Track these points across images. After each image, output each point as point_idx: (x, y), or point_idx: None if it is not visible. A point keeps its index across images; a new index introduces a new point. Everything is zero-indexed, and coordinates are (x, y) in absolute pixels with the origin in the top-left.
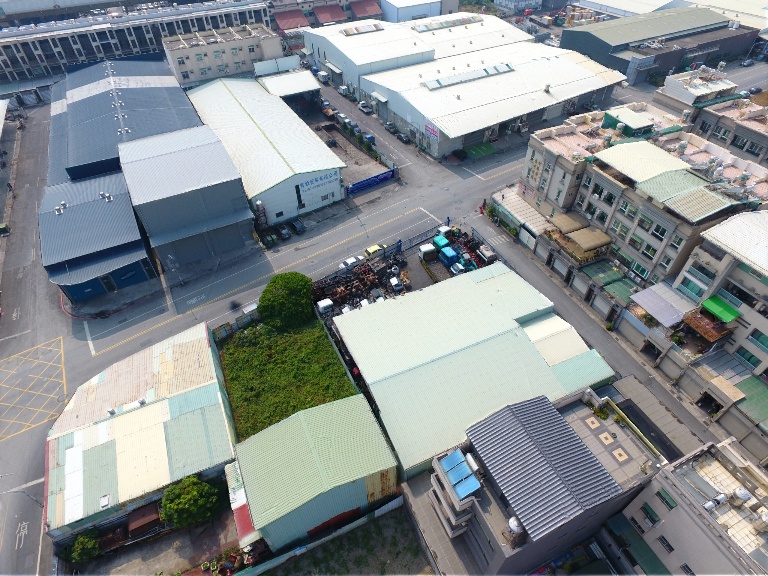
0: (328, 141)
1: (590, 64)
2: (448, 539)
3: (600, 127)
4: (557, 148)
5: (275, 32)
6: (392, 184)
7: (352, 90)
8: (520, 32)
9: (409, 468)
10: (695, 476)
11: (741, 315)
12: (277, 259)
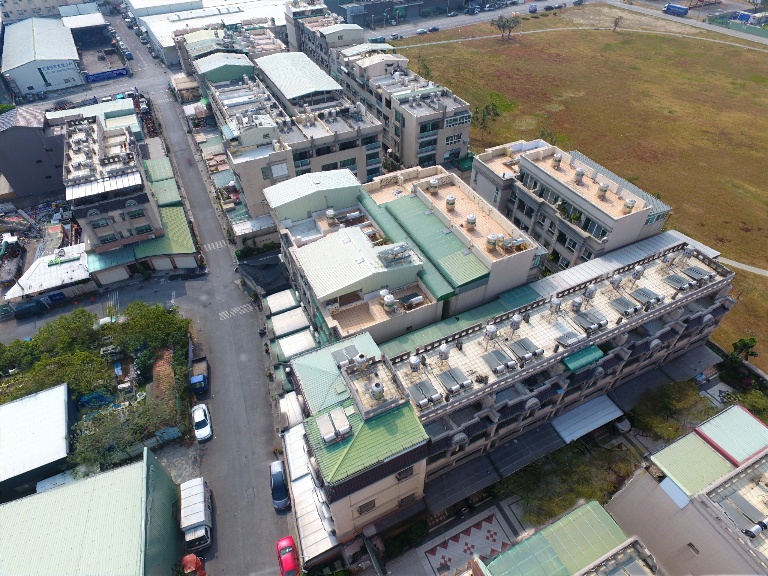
0: (98, 56)
1: None
2: None
3: None
4: None
5: None
6: (124, 77)
7: (140, 29)
8: None
9: None
10: None
11: (210, 102)
12: None
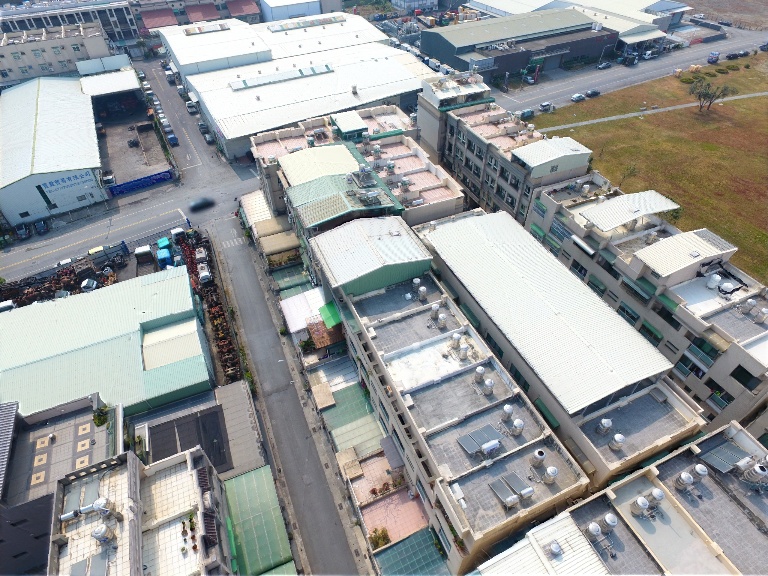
0: (129, 141)
1: (416, 66)
2: None
3: None
4: (272, 151)
5: None
6: (167, 185)
7: (186, 90)
8: (377, 33)
9: None
10: (94, 485)
11: (342, 322)
12: (1, 259)
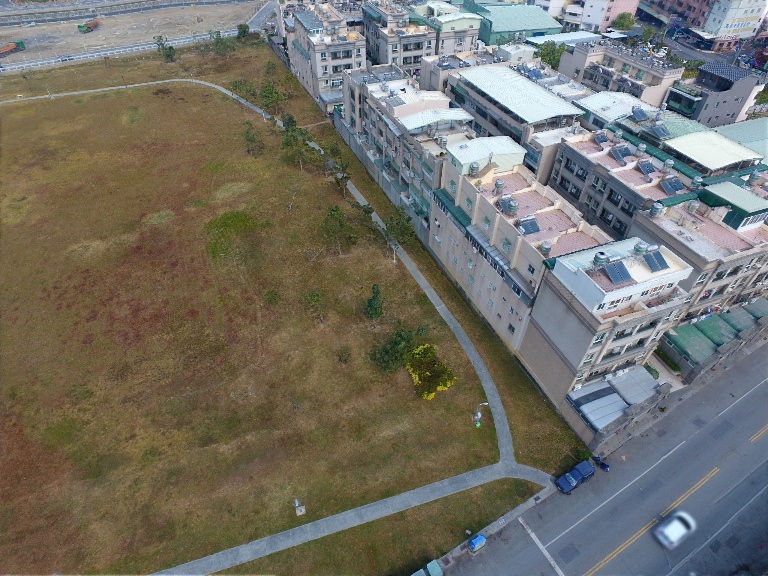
0: None
1: None
2: None
3: (763, 222)
4: None
5: None
6: None
7: None
8: None
9: (762, 117)
10: None
11: None
12: None
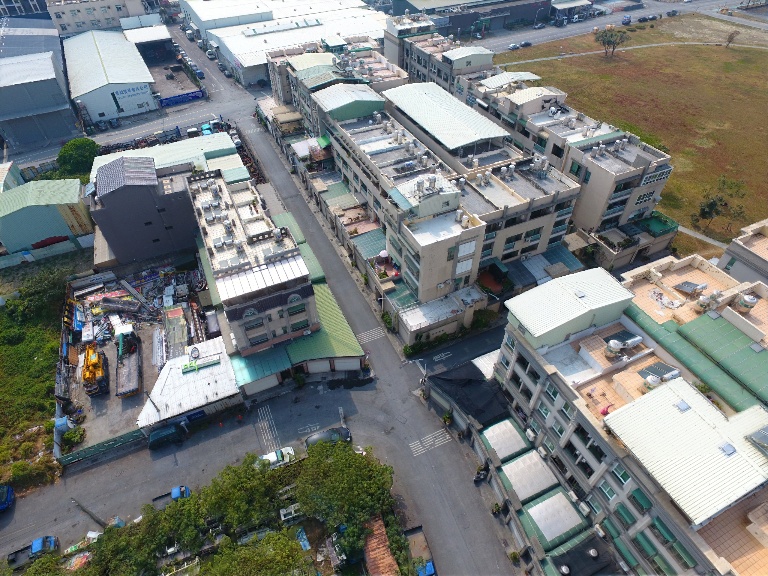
0: (167, 75)
1: None
2: (107, 243)
3: None
4: None
5: (161, 1)
6: (201, 101)
7: (205, 43)
8: (357, 1)
9: None
10: (204, 182)
11: (331, 143)
12: None
